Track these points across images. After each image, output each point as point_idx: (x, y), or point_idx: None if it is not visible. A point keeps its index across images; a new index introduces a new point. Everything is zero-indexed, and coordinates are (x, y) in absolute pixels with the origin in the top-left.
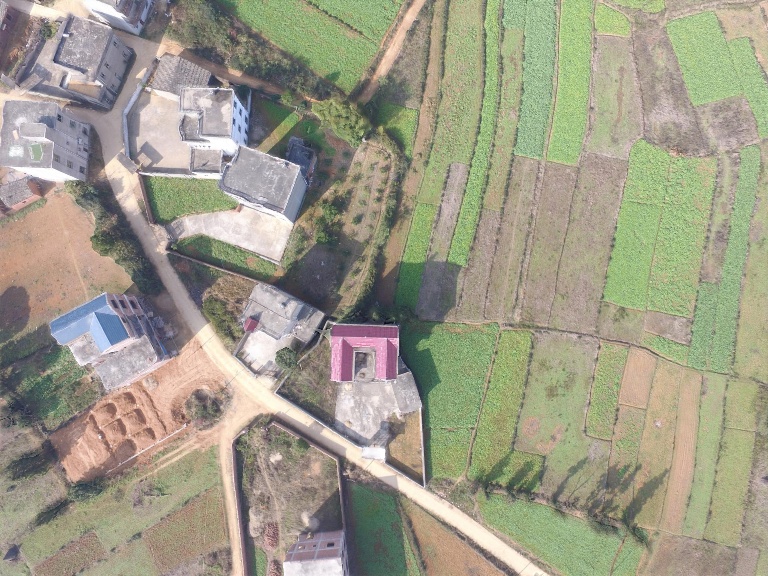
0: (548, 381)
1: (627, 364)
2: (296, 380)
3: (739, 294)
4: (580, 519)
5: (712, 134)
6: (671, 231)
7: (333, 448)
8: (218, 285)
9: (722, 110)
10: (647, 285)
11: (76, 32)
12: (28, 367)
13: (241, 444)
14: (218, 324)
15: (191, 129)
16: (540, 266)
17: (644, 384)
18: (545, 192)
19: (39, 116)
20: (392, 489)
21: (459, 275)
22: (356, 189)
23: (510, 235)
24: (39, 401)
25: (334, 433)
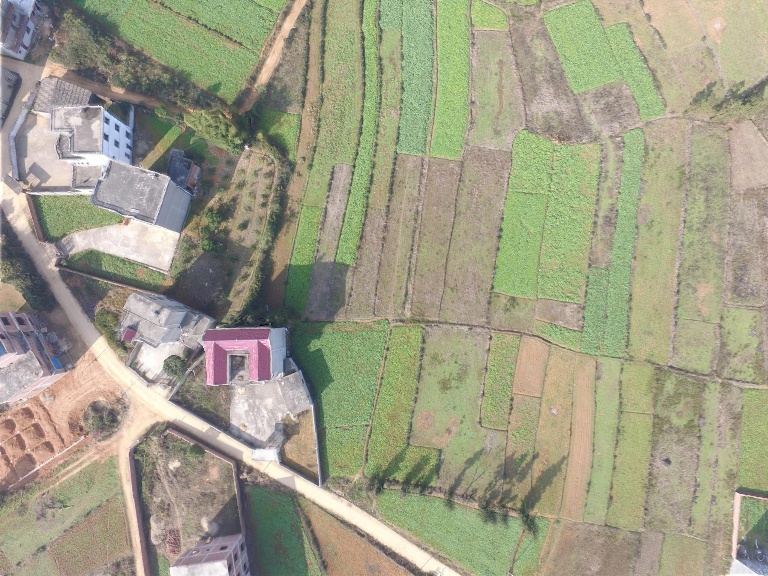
0: (441, 374)
1: (520, 353)
2: (190, 387)
3: (630, 277)
4: (479, 511)
5: (594, 120)
6: (558, 218)
7: (230, 452)
8: (109, 298)
9: (603, 96)
10: (536, 273)
11: None
12: None
13: (139, 453)
14: (110, 336)
15: (67, 147)
16: (428, 261)
17: (538, 372)
18: (430, 188)
19: None
20: (290, 490)
21: (347, 274)
22: (241, 196)
23: (397, 232)
24: None
25: None
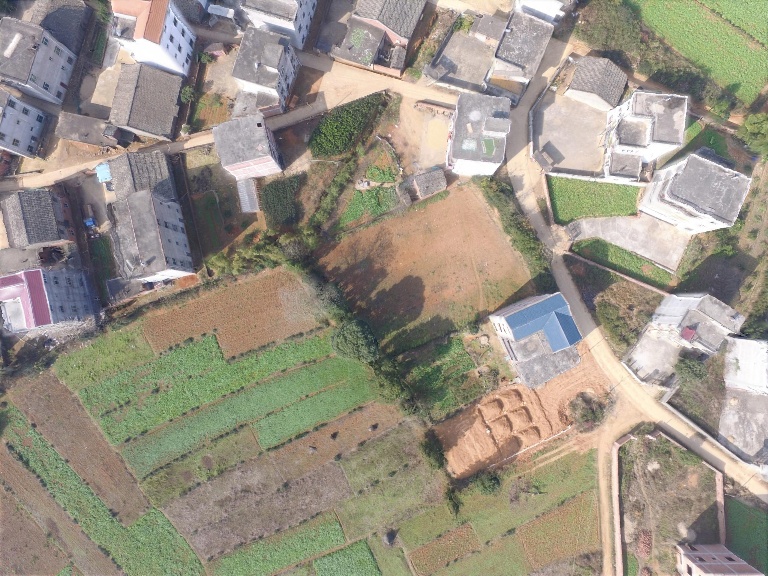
0: None
1: None
2: (681, 391)
3: None
4: None
5: None
6: None
7: (712, 461)
8: (612, 290)
9: None
10: None
11: (516, 28)
12: (420, 356)
13: (622, 450)
14: (612, 329)
15: (626, 133)
16: None
17: None
18: None
19: (493, 111)
20: None
21: None
22: (753, 203)
23: None
24: (427, 391)
25: (714, 447)
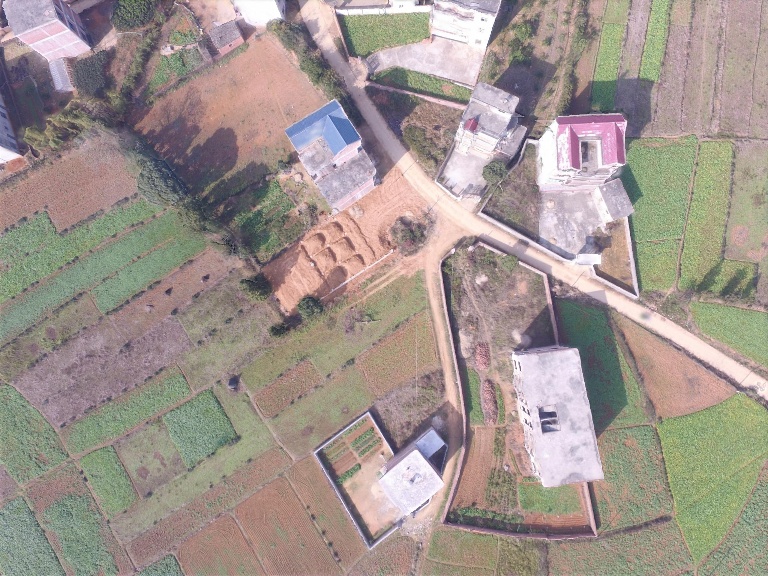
0: (753, 189)
1: None
2: (497, 201)
3: None
4: None
5: None
6: None
7: (538, 266)
8: (416, 113)
9: None
10: None
11: None
12: (240, 203)
13: (447, 267)
14: (419, 149)
15: None
16: (734, 77)
17: None
18: (733, 4)
19: None
20: (602, 303)
21: (652, 91)
22: (543, 13)
23: (700, 49)
24: (251, 235)
25: (538, 252)
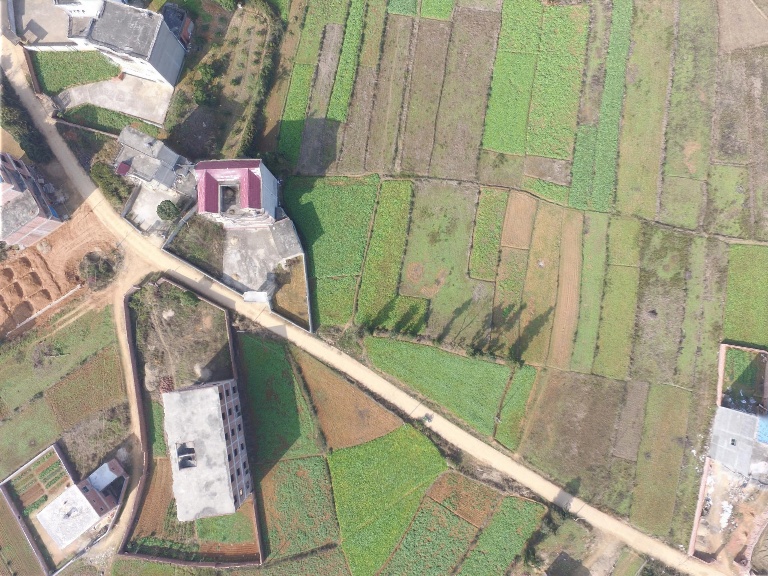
0: (430, 227)
1: (508, 207)
2: (184, 238)
3: (618, 135)
4: (467, 358)
5: None
6: (547, 77)
7: (223, 302)
8: (105, 150)
9: None
10: (525, 131)
11: None
12: None
13: (134, 302)
14: (105, 186)
15: None
16: (418, 118)
17: (526, 226)
18: (420, 47)
19: None
20: (281, 338)
21: (338, 130)
22: (234, 53)
23: (387, 90)
24: None
25: (223, 287)
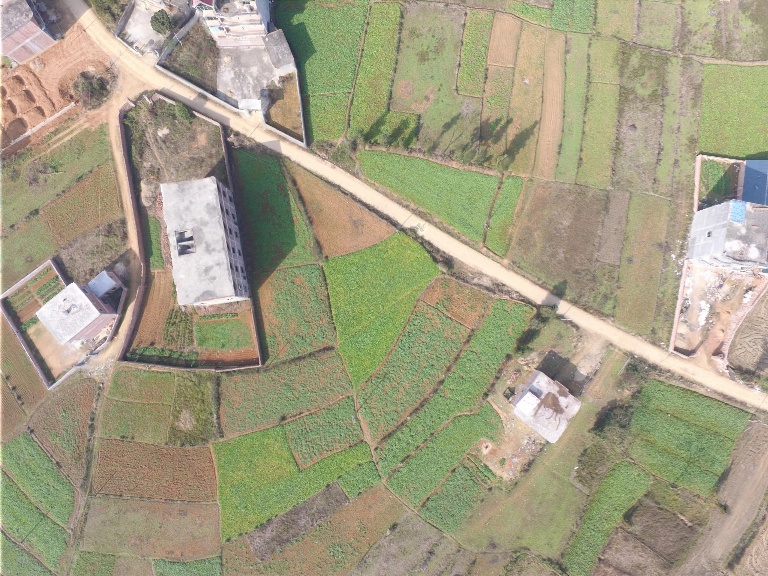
0: (419, 47)
1: (493, 28)
2: (177, 57)
3: None
4: (456, 169)
5: None
6: None
7: (217, 119)
8: None
9: None
10: None
11: None
12: None
13: (129, 119)
14: (98, 4)
15: None
16: None
17: (511, 45)
18: None
19: None
20: (276, 152)
21: None
22: None
23: None
24: None
25: (217, 105)
